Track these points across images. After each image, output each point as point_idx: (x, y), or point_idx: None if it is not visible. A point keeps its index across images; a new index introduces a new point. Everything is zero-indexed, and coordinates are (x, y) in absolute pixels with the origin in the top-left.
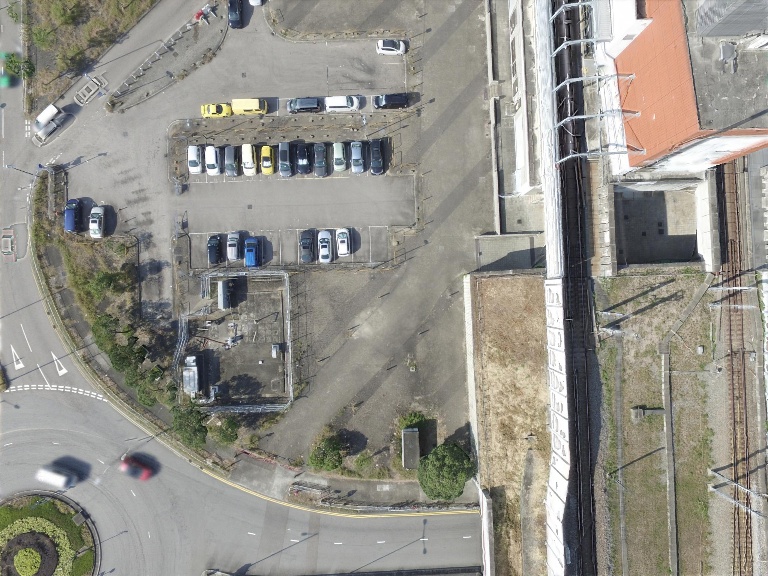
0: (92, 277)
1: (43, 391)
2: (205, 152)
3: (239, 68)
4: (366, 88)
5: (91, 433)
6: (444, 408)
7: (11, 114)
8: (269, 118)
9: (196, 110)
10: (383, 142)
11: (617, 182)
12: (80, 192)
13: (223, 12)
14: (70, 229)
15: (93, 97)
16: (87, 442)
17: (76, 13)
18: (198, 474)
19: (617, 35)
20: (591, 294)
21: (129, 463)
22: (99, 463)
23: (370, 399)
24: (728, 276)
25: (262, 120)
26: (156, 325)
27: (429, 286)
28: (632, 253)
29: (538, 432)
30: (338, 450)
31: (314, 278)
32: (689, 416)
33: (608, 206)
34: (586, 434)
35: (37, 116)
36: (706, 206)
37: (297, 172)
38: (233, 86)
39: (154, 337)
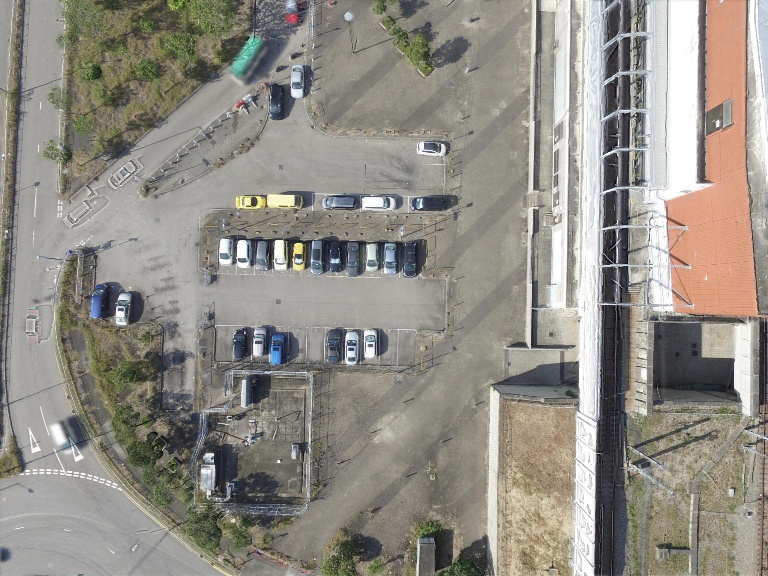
0: (115, 364)
1: (58, 476)
2: (237, 245)
3: (276, 160)
4: (403, 188)
5: (103, 522)
6: (462, 519)
7: (44, 193)
8: (303, 213)
9: (230, 200)
10: (417, 244)
11: (658, 321)
12: (108, 276)
13: (264, 102)
14: (96, 316)
15: (127, 180)
16: (99, 531)
17: (116, 95)
18: (209, 570)
19: (672, 187)
20: (623, 429)
21: (140, 554)
22: (109, 553)
23: (388, 505)
24: (765, 418)
25: (296, 214)
26: (176, 416)
27: (455, 394)
28: (664, 373)
29: (560, 565)
30: (352, 558)
31: (339, 378)
32: (715, 558)
33: (647, 344)
34: (609, 572)
35: (70, 197)
36: (747, 348)
37: (328, 269)
38: (269, 178)
39: (173, 428)
